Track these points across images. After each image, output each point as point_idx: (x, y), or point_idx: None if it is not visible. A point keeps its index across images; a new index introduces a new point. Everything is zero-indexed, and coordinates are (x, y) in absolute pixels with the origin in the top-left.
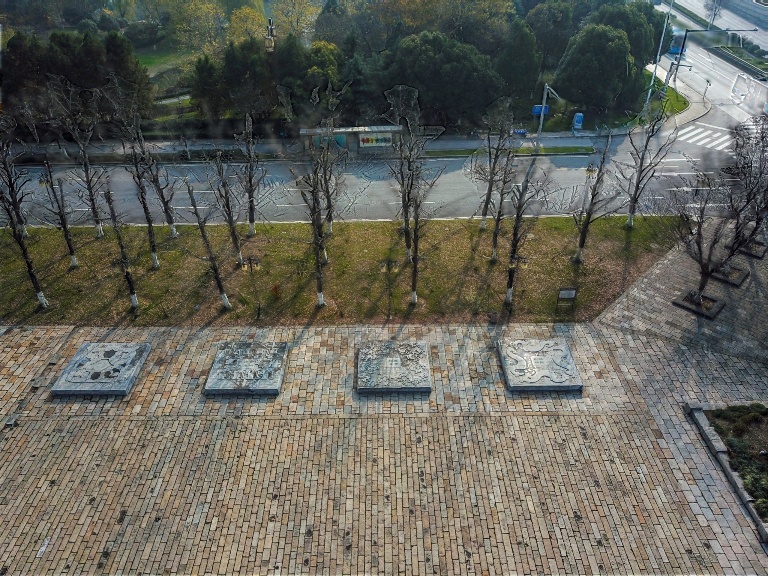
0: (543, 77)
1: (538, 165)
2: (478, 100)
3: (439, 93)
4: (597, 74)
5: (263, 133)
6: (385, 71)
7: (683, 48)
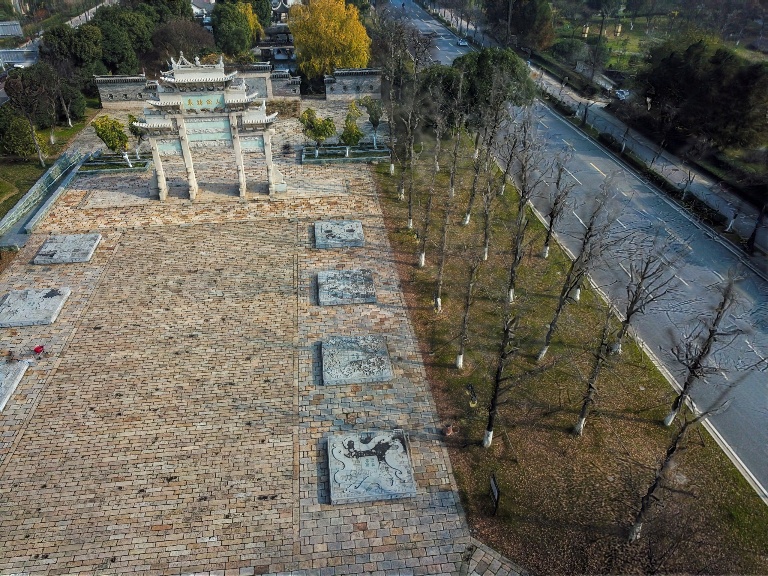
0: None
1: None
2: None
3: None
4: None
5: None
6: None
7: None
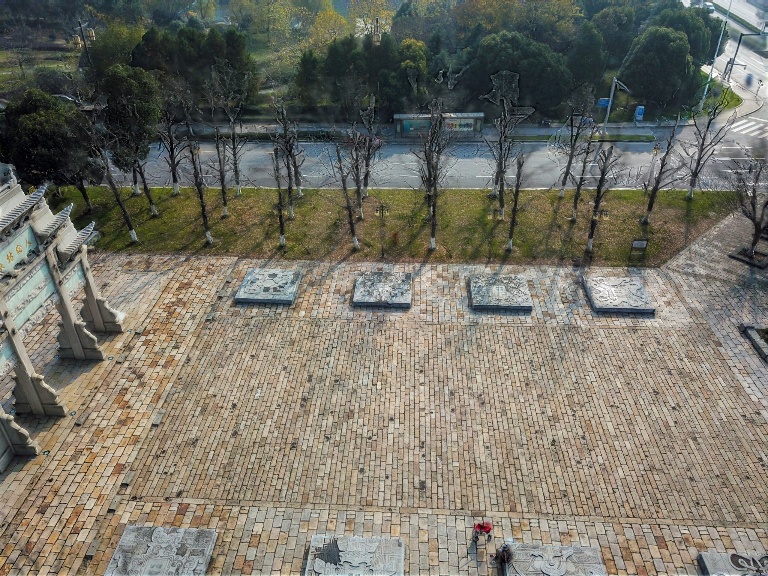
0: (605, 75)
1: None
2: (550, 92)
3: None
4: (659, 71)
5: (356, 119)
6: None
7: (737, 50)
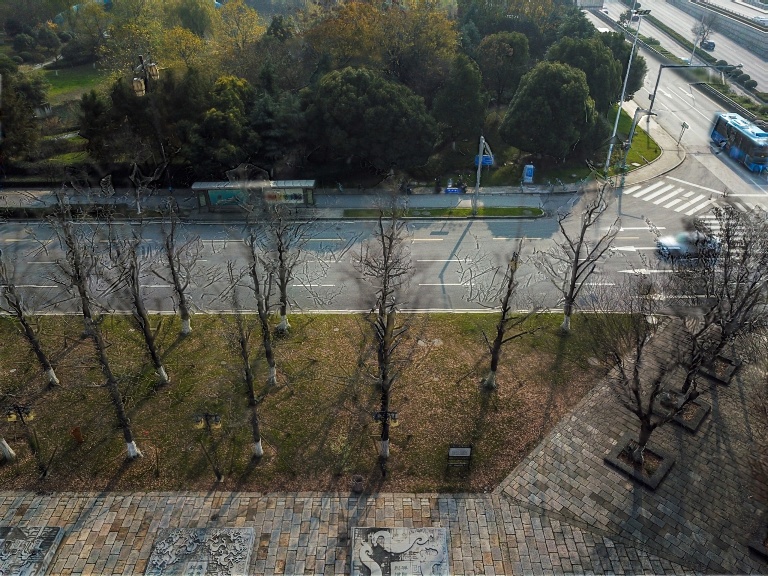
0: (498, 115)
1: (472, 232)
2: (409, 149)
3: (363, 140)
4: (550, 120)
5: (161, 181)
6: (301, 113)
7: (657, 85)
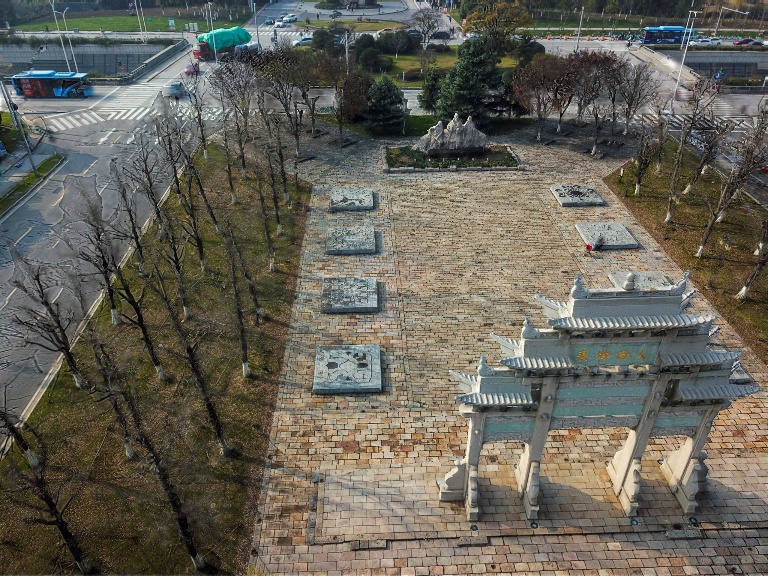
0: None
1: None
2: None
3: None
4: None
5: None
6: None
7: None
